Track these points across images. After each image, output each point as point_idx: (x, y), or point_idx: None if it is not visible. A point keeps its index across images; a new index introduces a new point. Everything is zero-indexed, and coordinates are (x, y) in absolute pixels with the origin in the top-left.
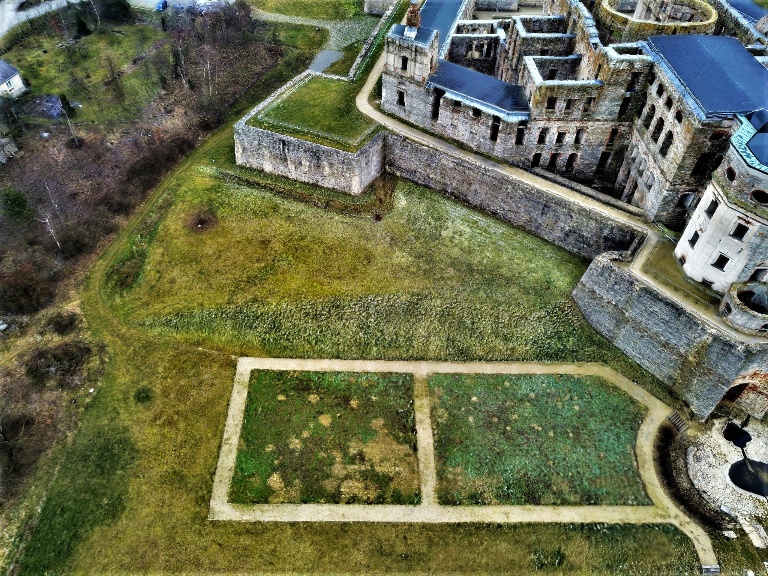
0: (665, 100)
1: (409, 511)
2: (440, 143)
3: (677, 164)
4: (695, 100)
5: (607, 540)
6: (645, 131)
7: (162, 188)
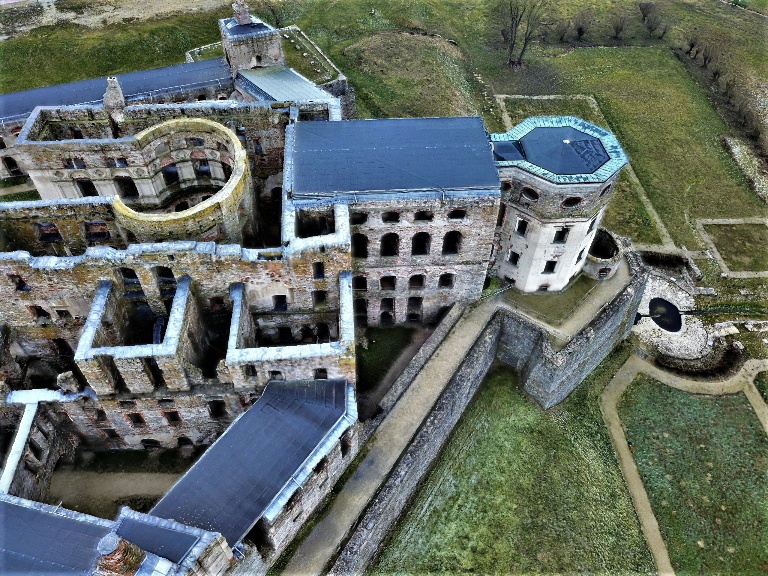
0: (413, 218)
1: None
2: (309, 551)
3: (491, 244)
4: (469, 189)
5: None
6: (394, 259)
7: None
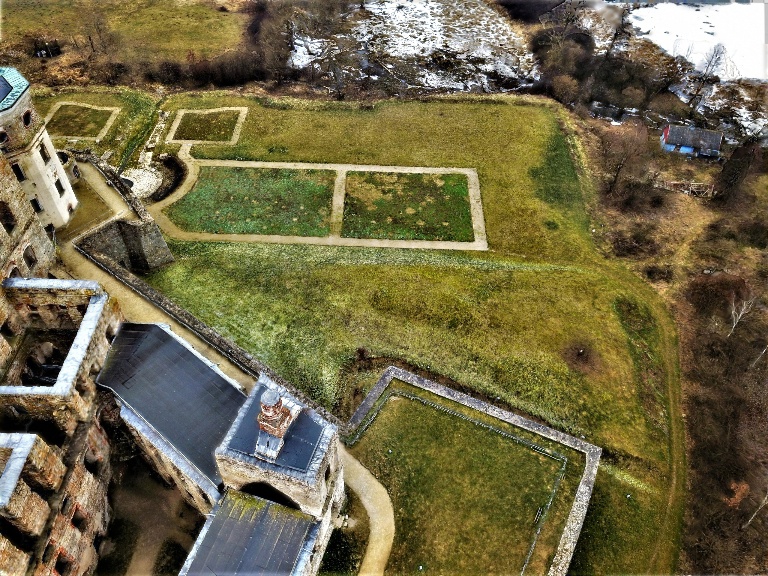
0: None
1: (355, 168)
2: None
3: None
4: None
5: (240, 154)
6: None
7: (678, 449)
